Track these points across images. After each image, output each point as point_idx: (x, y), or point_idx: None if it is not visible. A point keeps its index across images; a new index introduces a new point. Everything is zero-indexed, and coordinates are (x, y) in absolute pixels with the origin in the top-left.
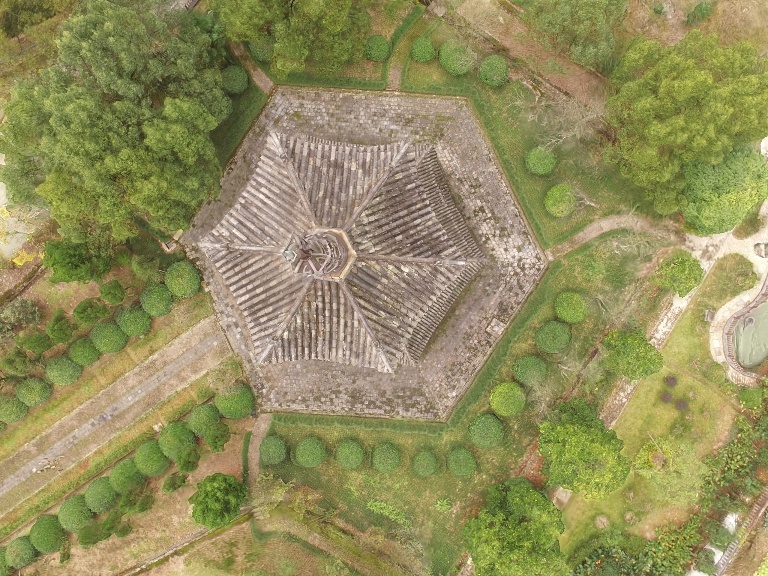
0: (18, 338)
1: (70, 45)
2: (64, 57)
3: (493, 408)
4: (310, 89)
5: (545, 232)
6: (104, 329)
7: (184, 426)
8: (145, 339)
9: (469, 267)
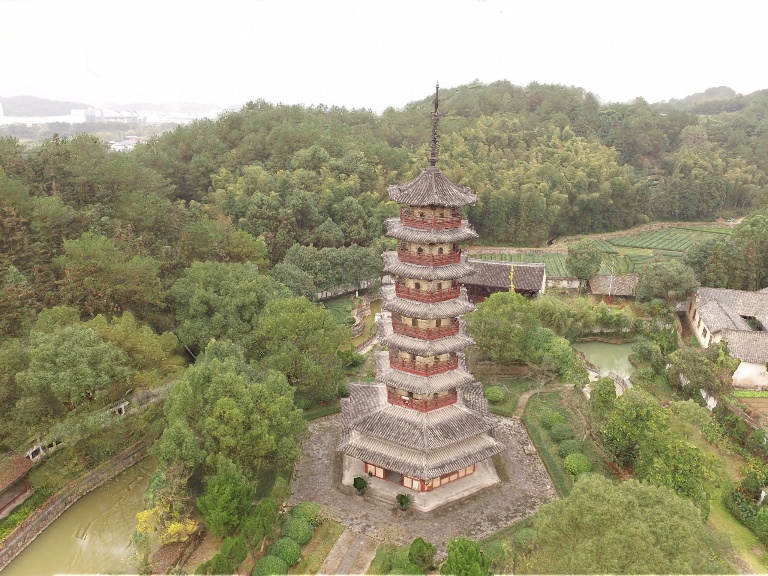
0: None
1: (214, 347)
2: (207, 359)
3: (576, 469)
4: (320, 418)
5: None
6: (266, 558)
7: None
8: (303, 563)
9: None
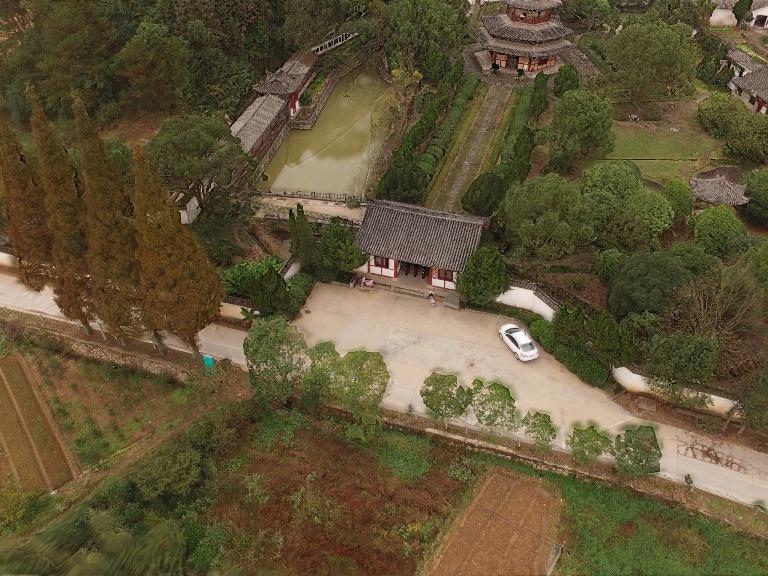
0: None
1: None
2: None
3: None
4: None
5: None
6: None
7: None
8: None
9: None
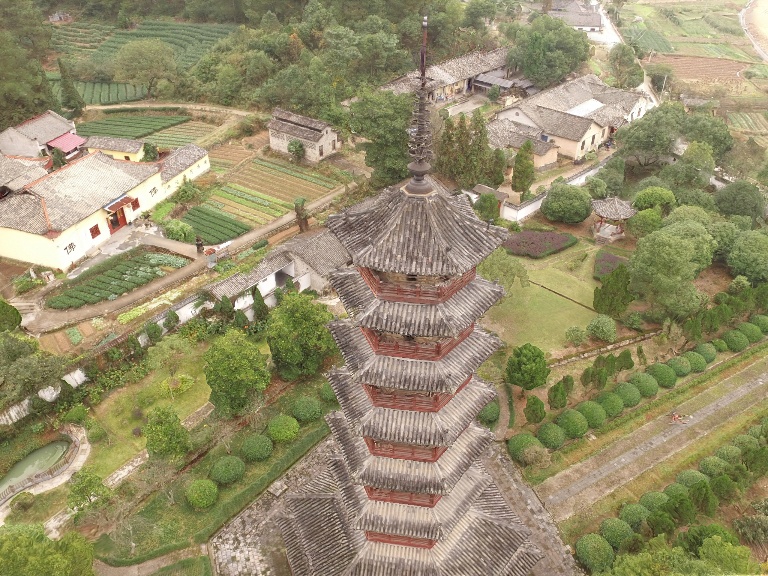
0: (740, 487)
1: None
2: None
3: None
4: None
5: (201, 573)
6: None
7: (568, 431)
8: None
9: (297, 492)
